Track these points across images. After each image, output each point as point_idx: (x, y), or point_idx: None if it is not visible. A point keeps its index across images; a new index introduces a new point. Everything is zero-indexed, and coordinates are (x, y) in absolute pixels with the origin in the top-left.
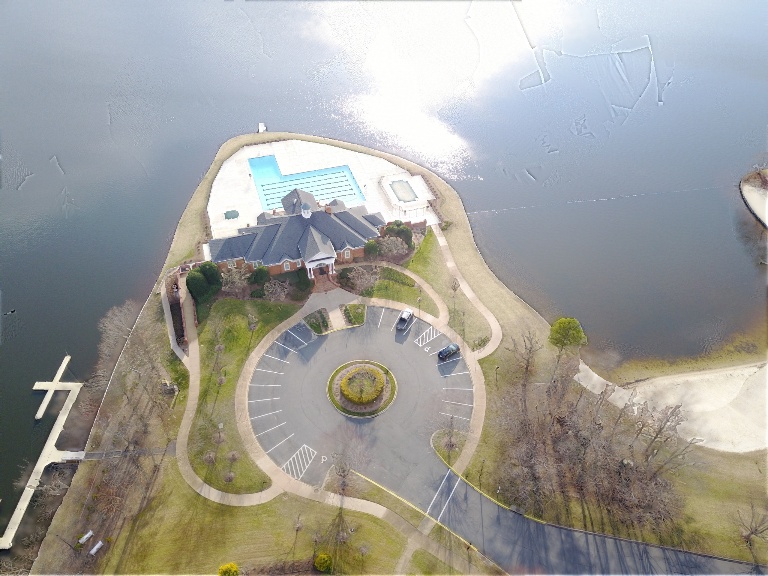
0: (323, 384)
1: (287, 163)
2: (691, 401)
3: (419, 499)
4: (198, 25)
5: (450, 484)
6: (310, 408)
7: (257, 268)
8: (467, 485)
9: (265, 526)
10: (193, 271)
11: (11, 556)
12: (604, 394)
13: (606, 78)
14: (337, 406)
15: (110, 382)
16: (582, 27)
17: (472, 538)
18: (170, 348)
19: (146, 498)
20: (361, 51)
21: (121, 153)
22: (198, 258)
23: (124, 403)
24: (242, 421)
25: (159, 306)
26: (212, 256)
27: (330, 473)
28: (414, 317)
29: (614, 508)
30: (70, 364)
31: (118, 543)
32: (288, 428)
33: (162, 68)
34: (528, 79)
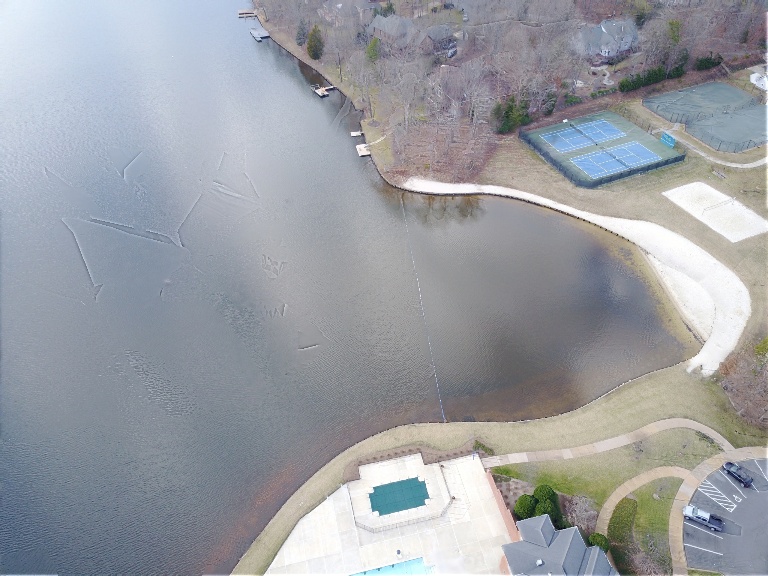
0: None
1: None
2: (702, 303)
3: None
4: None
5: None
6: None
7: None
8: None
9: None
10: None
11: None
12: None
13: (228, 210)
14: None
15: None
16: (75, 195)
17: None
18: None
19: None
20: None
21: None
22: None
23: None
24: None
25: None
26: None
27: None
28: None
29: None
30: None
31: None
32: None
33: None
34: None
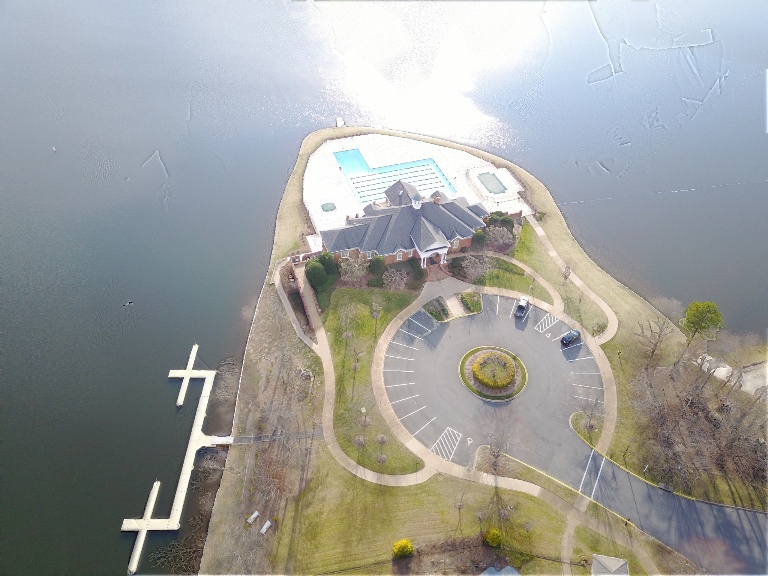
0: (454, 369)
1: (372, 156)
2: None
3: (569, 478)
4: (272, 21)
5: (596, 463)
6: (447, 392)
7: (374, 258)
8: (613, 464)
9: (427, 505)
10: (312, 261)
11: (181, 536)
12: (739, 376)
13: (677, 71)
14: (473, 390)
15: (243, 369)
16: (643, 22)
17: (628, 514)
18: (297, 336)
19: (304, 480)
20: (433, 46)
21: (200, 148)
22: (305, 249)
23: (261, 389)
24: (383, 405)
25: (276, 296)
26: (327, 247)
27: (479, 454)
28: (529, 304)
29: (758, 485)
30: (199, 353)
31: (286, 522)
32: (429, 412)
33: (240, 64)
34: (595, 73)
